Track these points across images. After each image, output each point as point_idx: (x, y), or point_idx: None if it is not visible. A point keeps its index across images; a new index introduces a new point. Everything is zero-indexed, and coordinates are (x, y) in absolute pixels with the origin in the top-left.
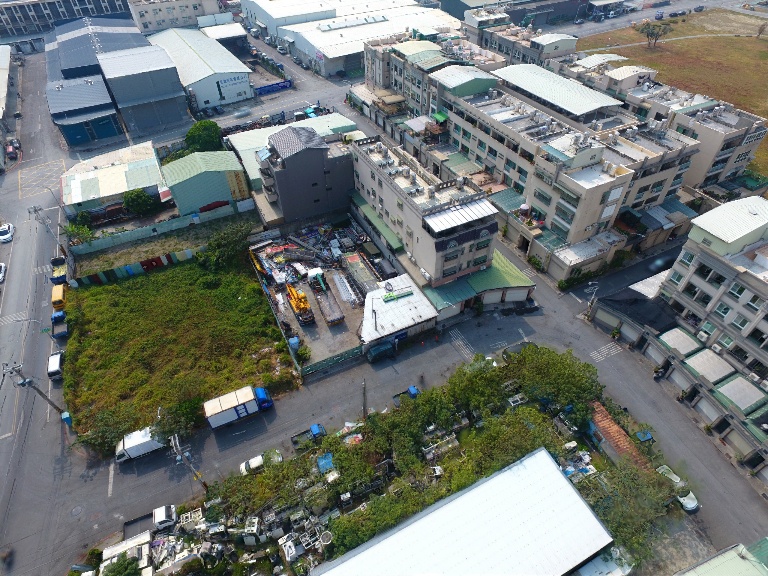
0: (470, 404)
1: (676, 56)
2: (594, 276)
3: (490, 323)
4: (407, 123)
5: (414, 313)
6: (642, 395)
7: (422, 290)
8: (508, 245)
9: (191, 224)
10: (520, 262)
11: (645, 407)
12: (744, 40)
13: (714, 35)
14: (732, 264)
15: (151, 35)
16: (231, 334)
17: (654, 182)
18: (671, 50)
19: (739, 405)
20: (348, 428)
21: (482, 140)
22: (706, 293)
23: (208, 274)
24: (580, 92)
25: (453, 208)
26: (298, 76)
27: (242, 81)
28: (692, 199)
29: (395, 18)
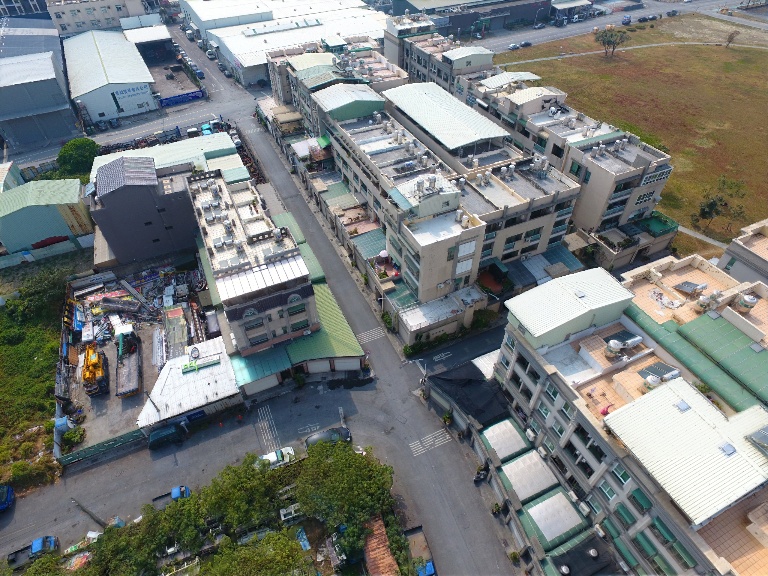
0: (225, 520)
1: (632, 67)
2: (451, 339)
3: (309, 399)
4: (294, 146)
5: (211, 389)
6: (453, 504)
7: (230, 359)
8: (367, 296)
9: (23, 262)
10: (373, 318)
11: (450, 522)
12: (712, 49)
13: (681, 43)
14: (542, 361)
15: (69, 38)
16: (5, 406)
17: (526, 231)
18: (629, 60)
19: (546, 534)
20: (88, 540)
21: (355, 172)
22: (527, 387)
23: (13, 326)
24: (466, 119)
25: (256, 268)
26: (217, 85)
27: (143, 92)
28: (584, 246)
29: (331, 22)
